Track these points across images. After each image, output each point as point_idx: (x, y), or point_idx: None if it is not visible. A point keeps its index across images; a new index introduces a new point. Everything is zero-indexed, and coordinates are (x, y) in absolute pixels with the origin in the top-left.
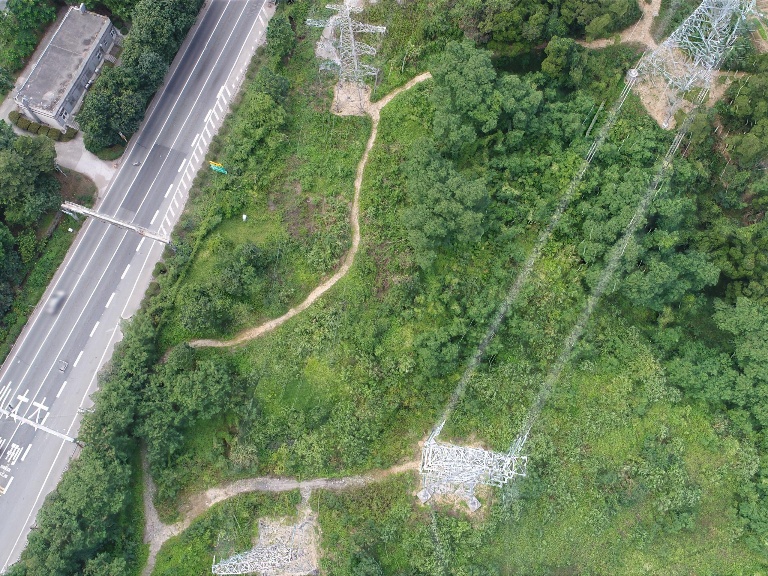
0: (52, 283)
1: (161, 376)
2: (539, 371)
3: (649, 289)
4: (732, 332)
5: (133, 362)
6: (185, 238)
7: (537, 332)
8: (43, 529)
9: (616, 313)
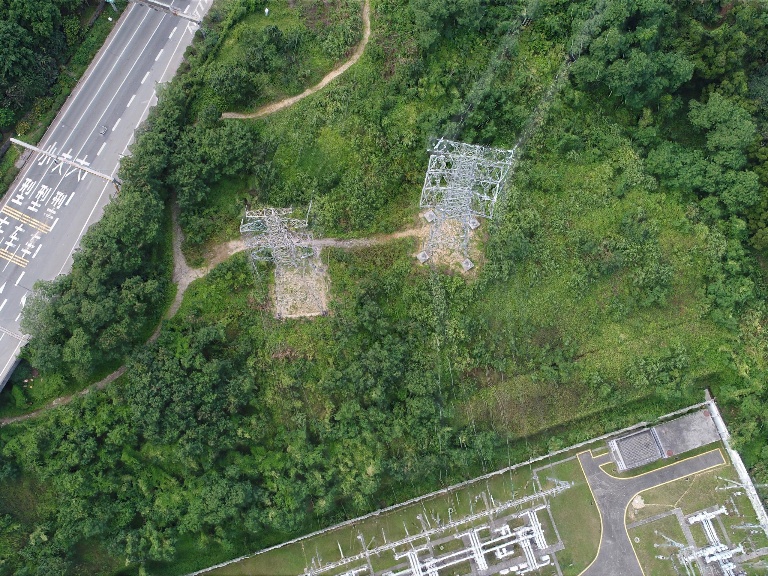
0: (93, 63)
1: (191, 133)
2: (529, 158)
3: (629, 76)
4: (704, 125)
5: (167, 120)
6: (213, 29)
7: (528, 116)
8: (87, 249)
9: (600, 111)
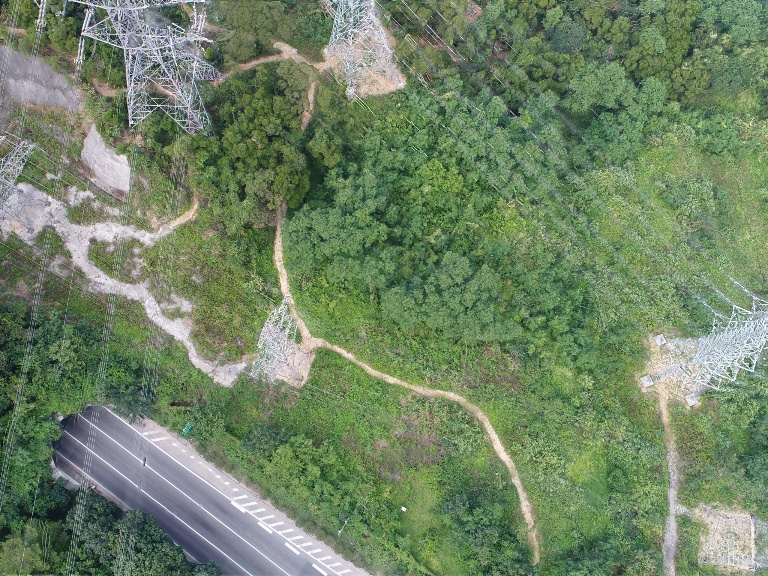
0: None
1: None
2: (594, 267)
3: None
4: None
5: None
6: None
7: None
8: None
9: None
